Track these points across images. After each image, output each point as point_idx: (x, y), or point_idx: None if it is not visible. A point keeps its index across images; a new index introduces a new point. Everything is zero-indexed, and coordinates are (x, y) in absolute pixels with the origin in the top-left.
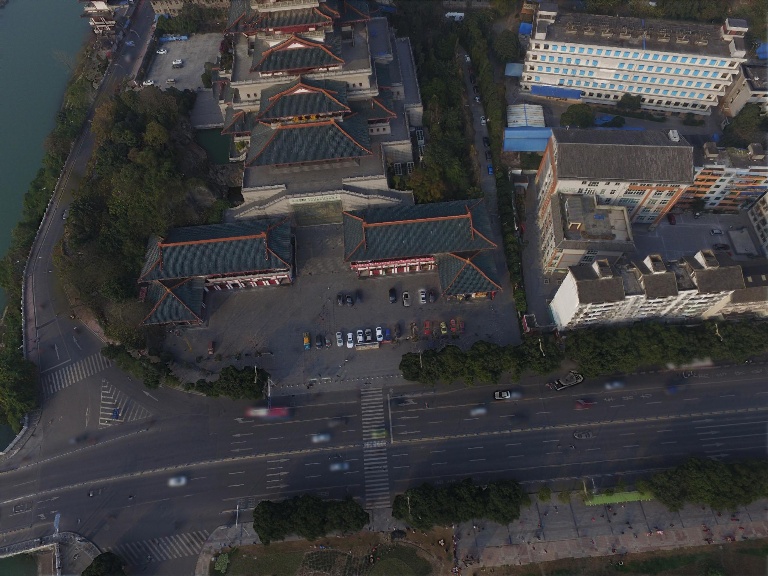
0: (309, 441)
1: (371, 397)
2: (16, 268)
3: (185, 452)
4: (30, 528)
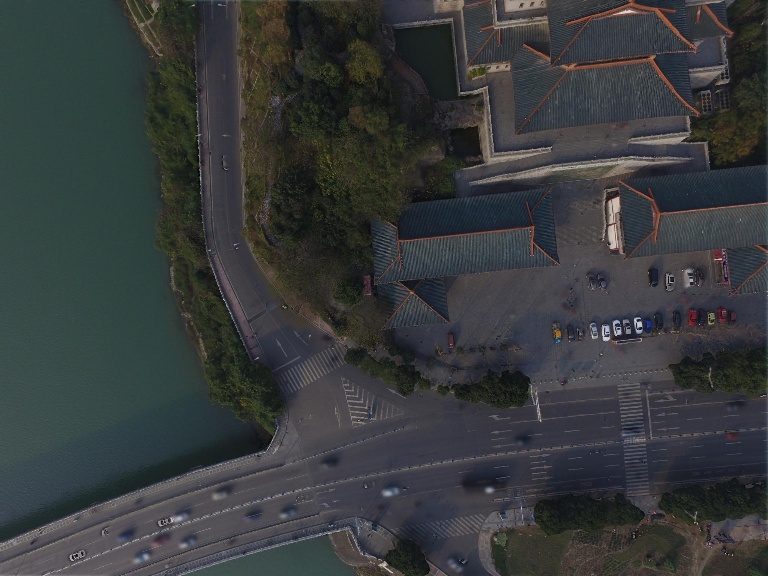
0: (569, 437)
1: (629, 393)
2: (198, 248)
3: (447, 449)
4: (318, 515)
